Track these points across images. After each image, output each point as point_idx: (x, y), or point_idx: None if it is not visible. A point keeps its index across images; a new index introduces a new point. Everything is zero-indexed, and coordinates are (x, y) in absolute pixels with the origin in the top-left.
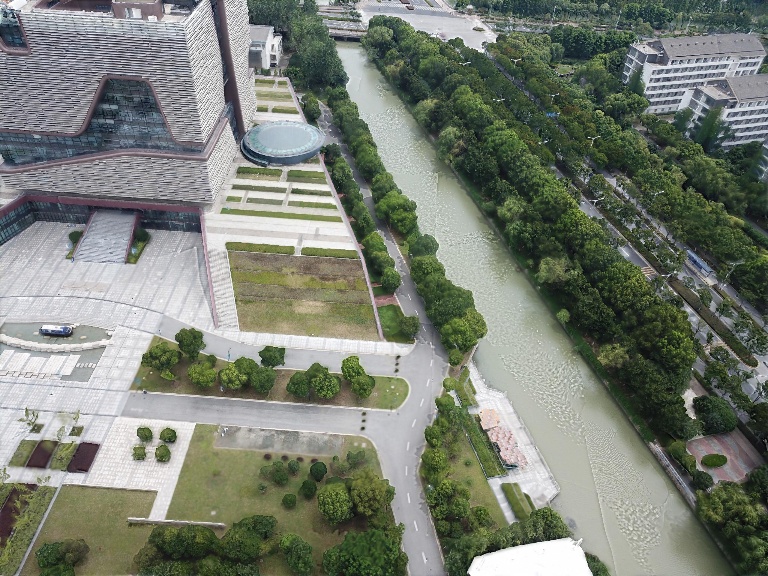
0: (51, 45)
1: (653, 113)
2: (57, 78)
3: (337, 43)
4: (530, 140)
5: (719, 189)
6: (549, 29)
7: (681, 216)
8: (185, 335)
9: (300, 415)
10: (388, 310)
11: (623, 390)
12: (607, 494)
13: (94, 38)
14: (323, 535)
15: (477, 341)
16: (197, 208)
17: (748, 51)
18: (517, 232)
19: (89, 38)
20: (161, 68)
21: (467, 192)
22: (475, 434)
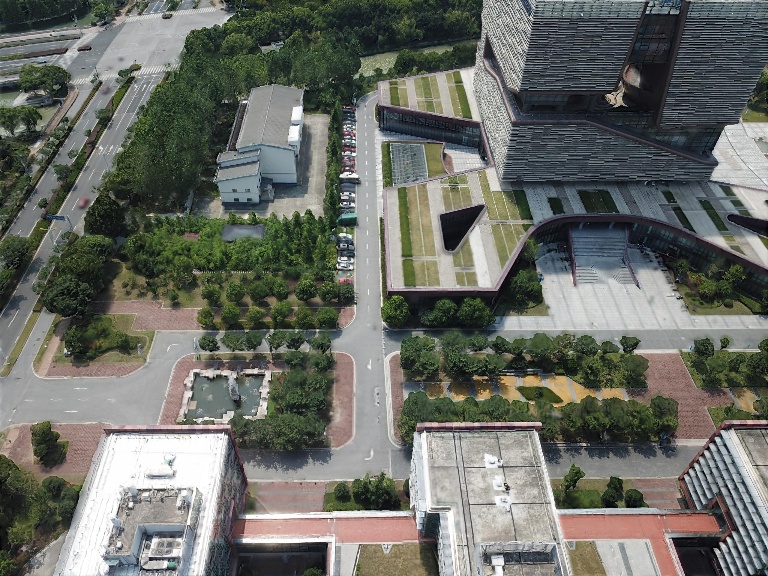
0: None
1: None
2: None
3: None
4: None
5: None
6: None
7: None
8: None
9: None
10: None
11: None
12: None
13: None
14: None
15: None
16: None
17: None
18: None
19: None
20: None
21: None
22: None
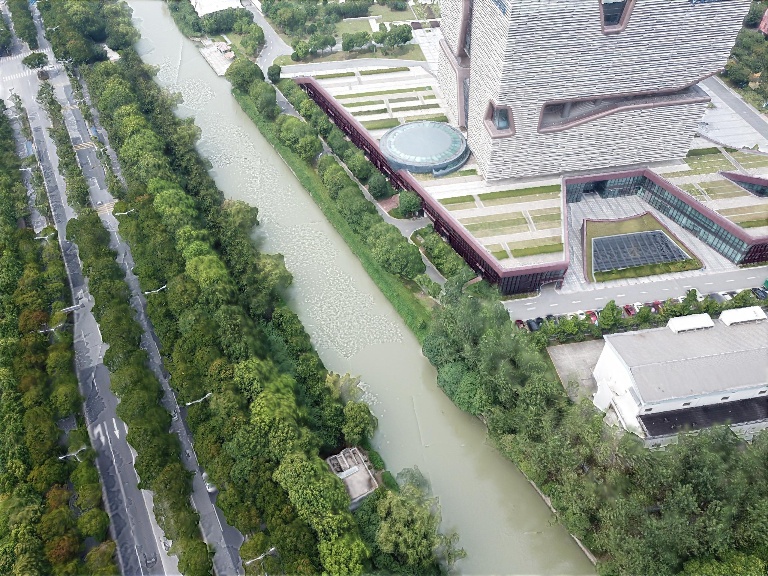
0: None
1: None
2: None
3: None
4: None
5: None
6: None
7: None
8: None
9: (328, 48)
10: None
11: None
12: None
13: None
14: None
15: None
16: None
17: None
18: None
19: None
20: None
21: None
22: None
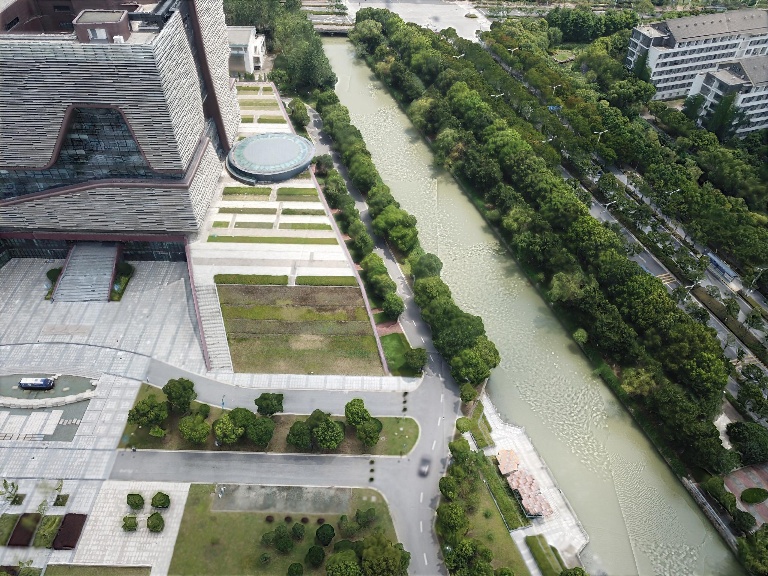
0: (8, 75)
1: (660, 99)
2: (19, 110)
3: (323, 39)
4: (533, 139)
5: (738, 183)
6: (545, 12)
7: (699, 215)
8: (173, 387)
9: (303, 467)
10: (392, 340)
11: (650, 418)
12: (639, 536)
13: (55, 65)
14: None
15: (490, 373)
16: (182, 237)
17: (759, 28)
18: (526, 245)
19: (49, 66)
20: (131, 94)
21: (469, 199)
22: (493, 479)
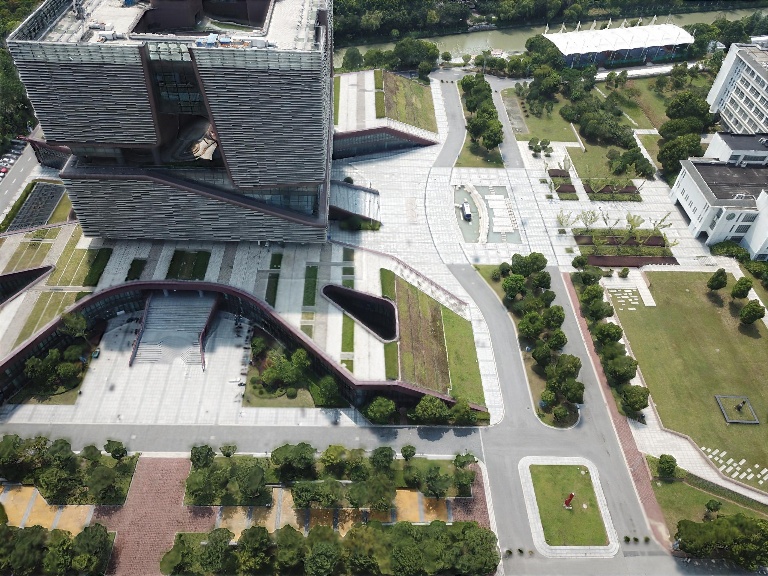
0: None
1: None
2: None
3: None
4: None
5: None
6: None
7: None
8: None
9: None
10: None
11: None
12: None
13: None
14: (559, 100)
15: None
16: None
17: None
18: None
19: None
20: None
21: None
22: None
